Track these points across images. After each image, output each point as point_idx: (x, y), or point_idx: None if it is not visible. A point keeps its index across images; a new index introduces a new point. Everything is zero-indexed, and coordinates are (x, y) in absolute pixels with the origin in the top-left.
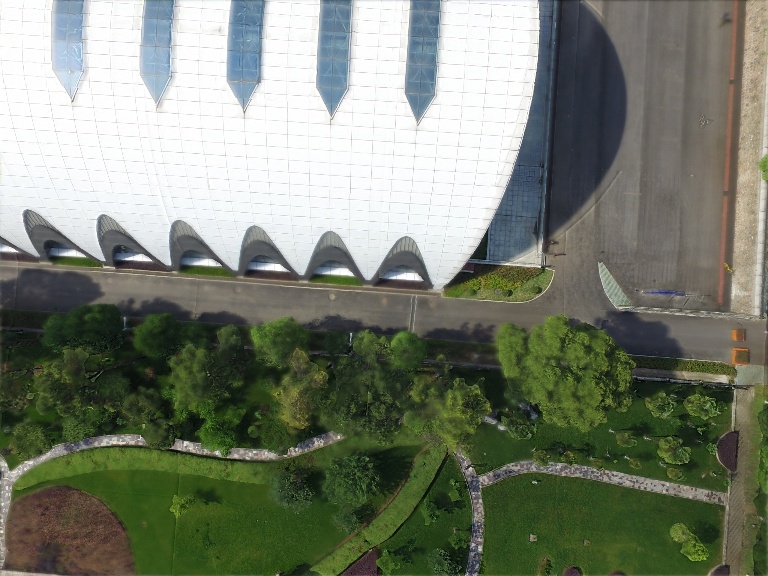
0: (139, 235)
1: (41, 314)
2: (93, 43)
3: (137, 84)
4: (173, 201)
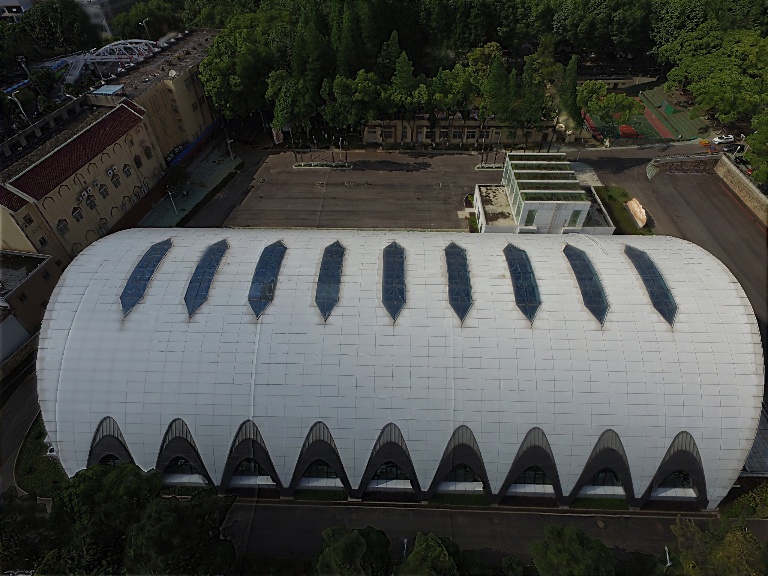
0: (416, 447)
1: (278, 559)
2: (413, 286)
3: (446, 309)
4: (463, 404)
